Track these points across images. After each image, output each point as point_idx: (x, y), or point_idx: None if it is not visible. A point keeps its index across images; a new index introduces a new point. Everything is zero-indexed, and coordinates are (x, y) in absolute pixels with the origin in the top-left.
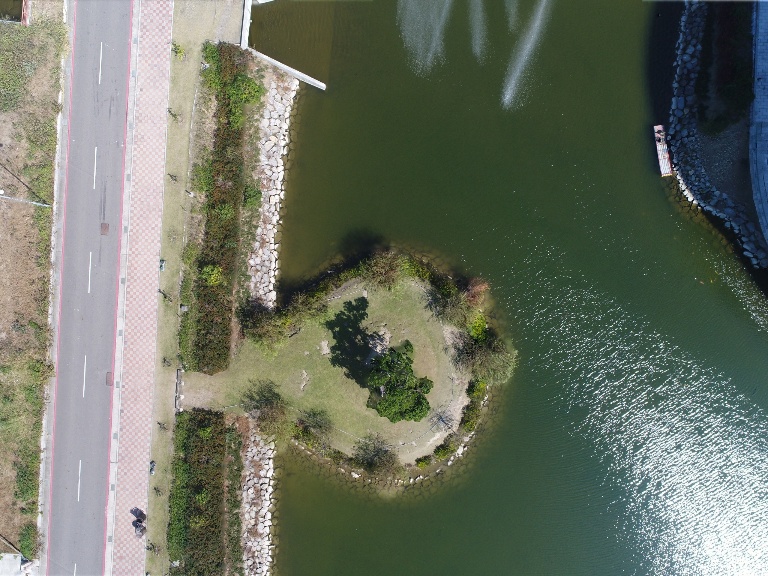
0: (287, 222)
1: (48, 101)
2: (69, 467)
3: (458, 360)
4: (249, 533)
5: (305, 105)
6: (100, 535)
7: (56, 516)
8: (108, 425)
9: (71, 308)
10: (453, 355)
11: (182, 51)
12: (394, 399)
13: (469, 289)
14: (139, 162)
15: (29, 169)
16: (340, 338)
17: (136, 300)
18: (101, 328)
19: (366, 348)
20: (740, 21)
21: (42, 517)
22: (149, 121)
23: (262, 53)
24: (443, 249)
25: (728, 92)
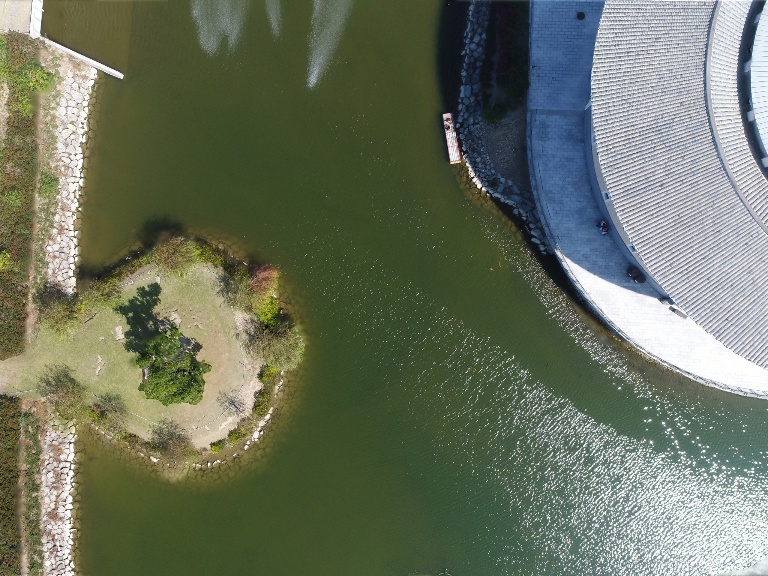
0: (87, 209)
1: None
2: None
3: (249, 345)
4: (48, 516)
5: (104, 94)
6: None
7: None
8: None
9: None
10: (244, 340)
11: None
12: (157, 381)
13: (256, 275)
14: None
15: None
16: (134, 323)
17: None
18: None
19: (156, 333)
20: (517, 10)
21: None
22: None
23: (61, 42)
24: (241, 236)
25: (503, 80)
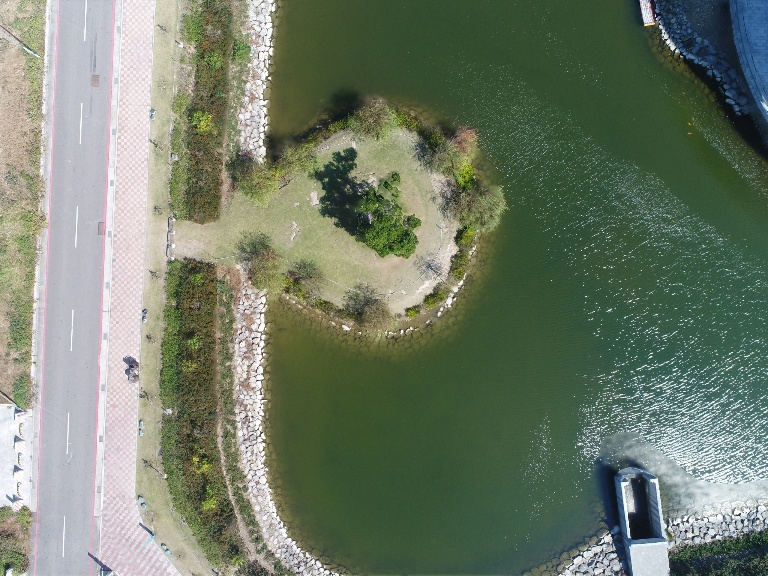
0: (276, 79)
1: None
2: (62, 317)
3: (446, 208)
4: (241, 386)
5: None
6: (93, 384)
7: (49, 366)
8: (100, 274)
9: (63, 159)
10: (441, 203)
11: None
12: (382, 226)
13: (456, 135)
14: (129, 14)
15: (20, 21)
16: (329, 189)
17: (127, 150)
18: (93, 178)
19: (355, 196)
20: None
21: (35, 367)
22: None
23: None
24: (430, 104)
25: None
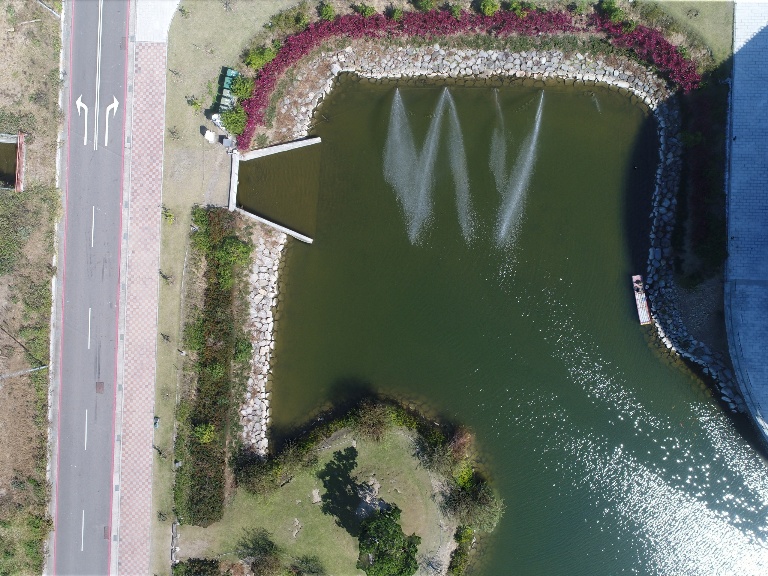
0: (277, 371)
1: (43, 264)
2: None
3: (446, 507)
4: None
5: (293, 257)
6: None
7: None
8: None
9: (68, 464)
10: (441, 502)
11: (172, 215)
12: (382, 566)
13: (455, 441)
14: (132, 322)
15: (25, 331)
16: (331, 487)
17: (131, 456)
18: (98, 483)
19: (356, 498)
20: (713, 180)
21: None
22: (141, 282)
23: (250, 208)
24: (430, 395)
25: (702, 251)
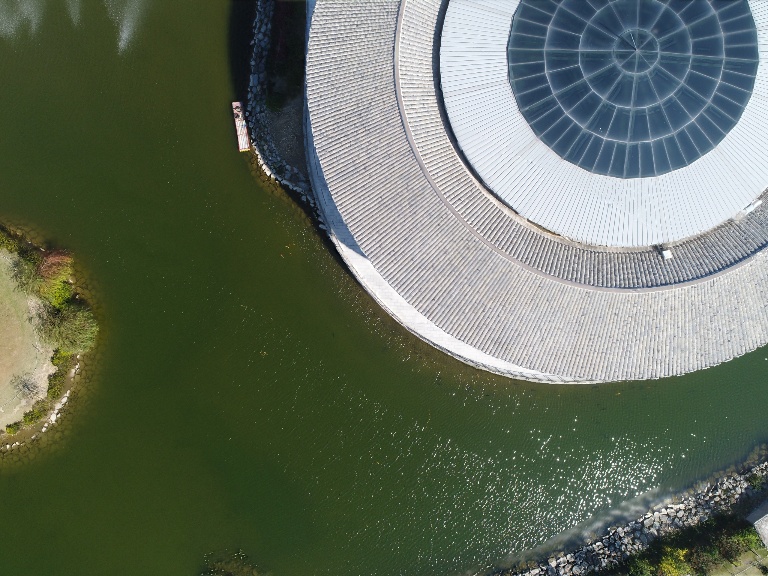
0: None
1: None
2: None
3: (41, 329)
4: None
5: None
6: None
7: None
8: None
9: None
10: (37, 324)
11: None
12: None
13: (45, 260)
14: None
15: None
16: None
17: None
18: None
19: None
20: None
21: None
22: None
23: None
24: (40, 222)
25: (279, 68)
